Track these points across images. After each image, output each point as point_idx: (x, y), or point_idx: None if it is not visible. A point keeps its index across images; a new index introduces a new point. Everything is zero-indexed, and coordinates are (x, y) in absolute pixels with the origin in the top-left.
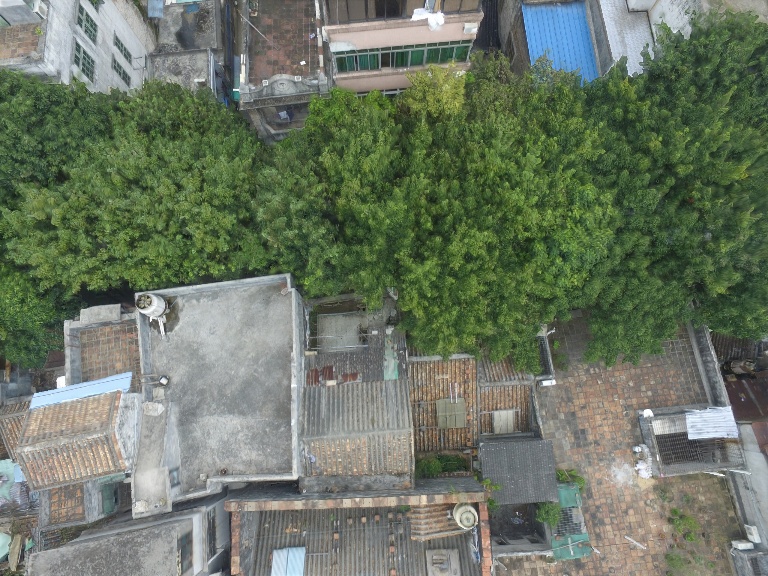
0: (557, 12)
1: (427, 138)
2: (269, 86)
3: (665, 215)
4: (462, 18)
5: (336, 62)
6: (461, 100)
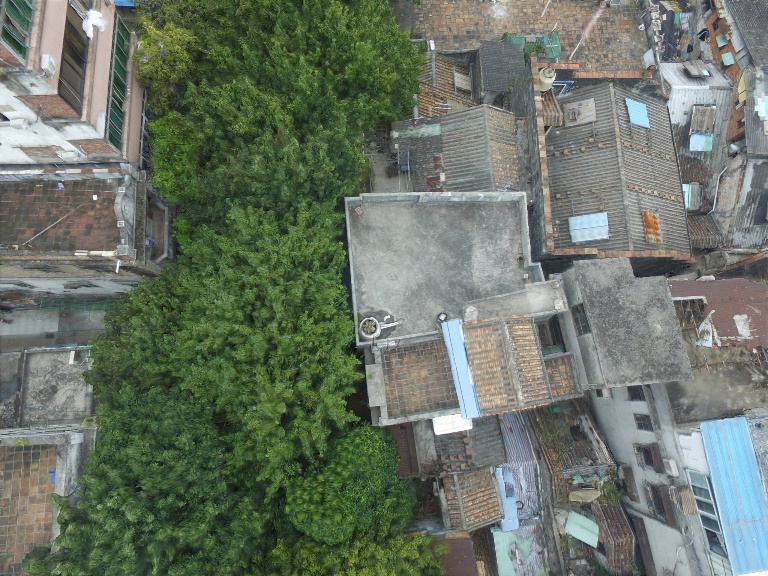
0: None
1: (225, 51)
2: (125, 222)
3: None
4: None
5: (112, 144)
6: None
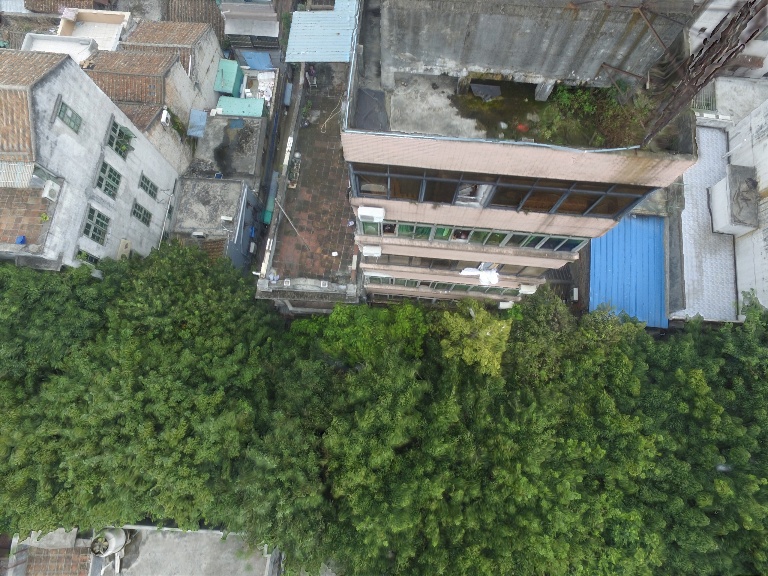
0: (630, 225)
1: (453, 417)
2: (291, 285)
3: (718, 562)
4: (519, 280)
5: (369, 278)
6: (502, 348)
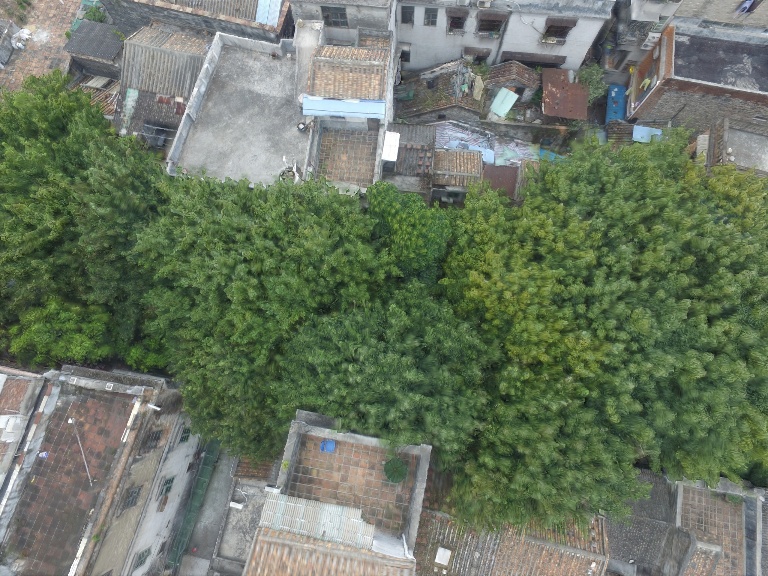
0: None
1: None
2: None
3: None
4: None
5: None
6: None
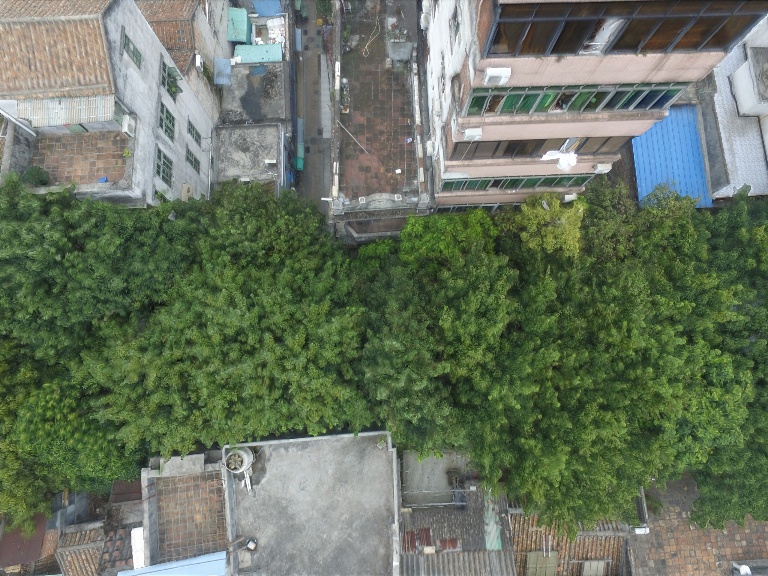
0: None
1: (552, 294)
2: (365, 203)
3: None
4: (596, 159)
5: (443, 184)
6: (577, 234)
